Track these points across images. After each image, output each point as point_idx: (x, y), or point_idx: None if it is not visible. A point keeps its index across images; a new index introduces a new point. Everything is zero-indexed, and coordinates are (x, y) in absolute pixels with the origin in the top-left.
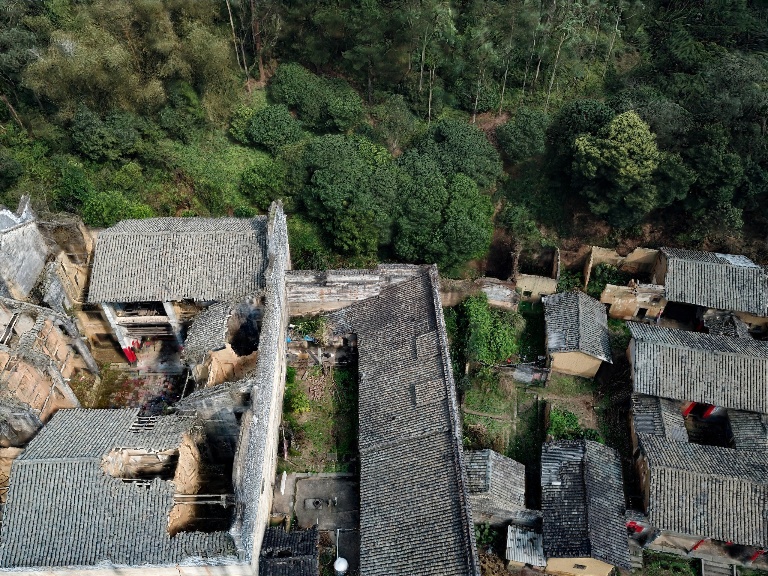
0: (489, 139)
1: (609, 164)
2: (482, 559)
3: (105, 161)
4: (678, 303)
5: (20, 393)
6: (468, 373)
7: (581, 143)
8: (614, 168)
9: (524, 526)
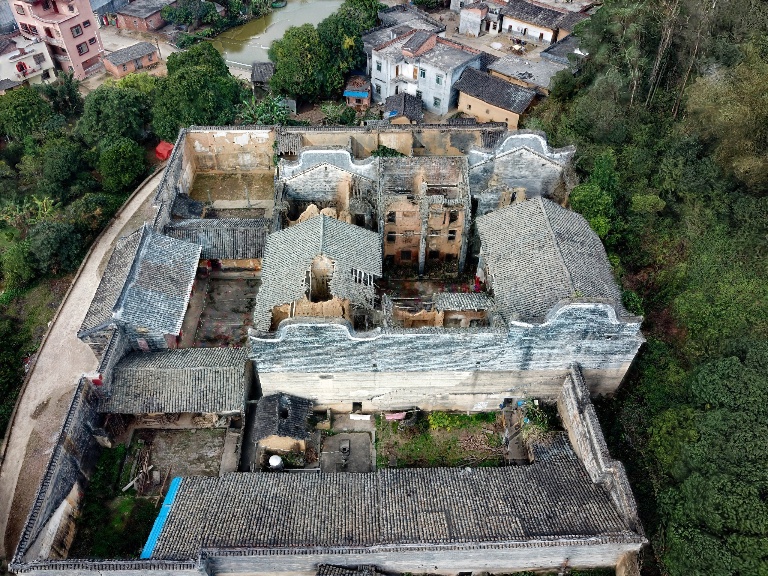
0: None
1: None
2: None
3: None
4: None
5: (401, 215)
6: None
7: None
8: None
9: None
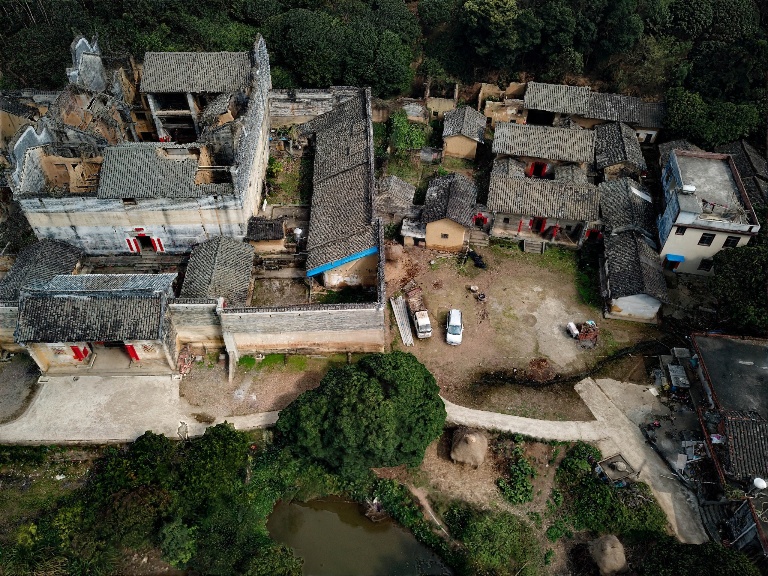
0: (416, 18)
1: (484, 15)
2: (388, 243)
3: (145, 26)
4: (537, 116)
5: None
6: (390, 155)
7: (467, 4)
8: (487, 18)
9: (413, 218)
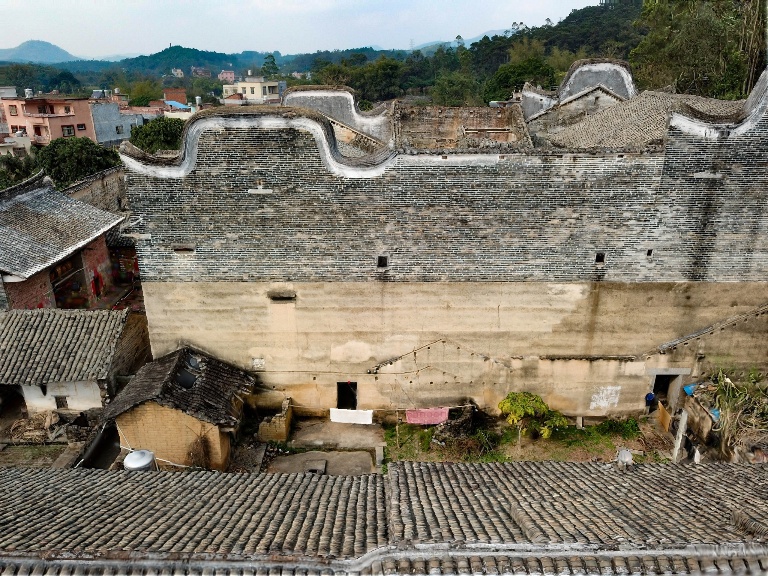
0: None
1: None
2: None
3: None
4: None
5: None
6: None
7: None
8: None
9: None
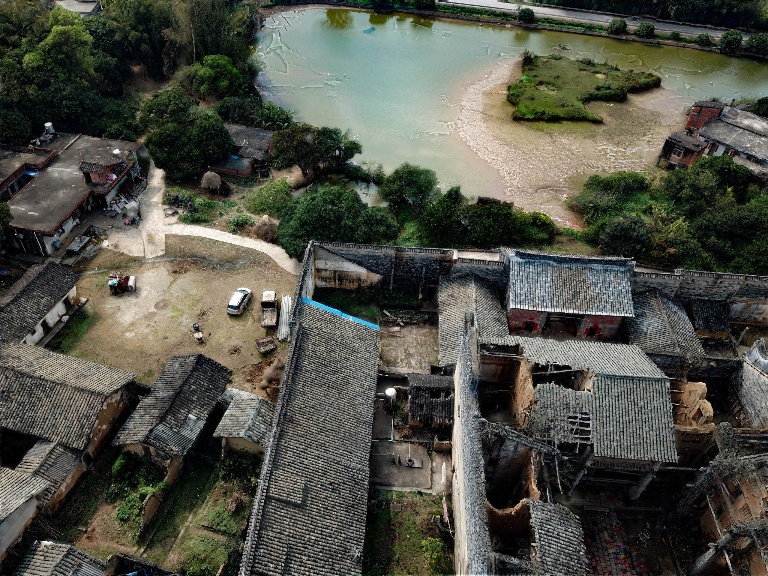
0: None
1: None
2: None
3: None
4: None
5: None
6: None
7: None
8: None
9: None
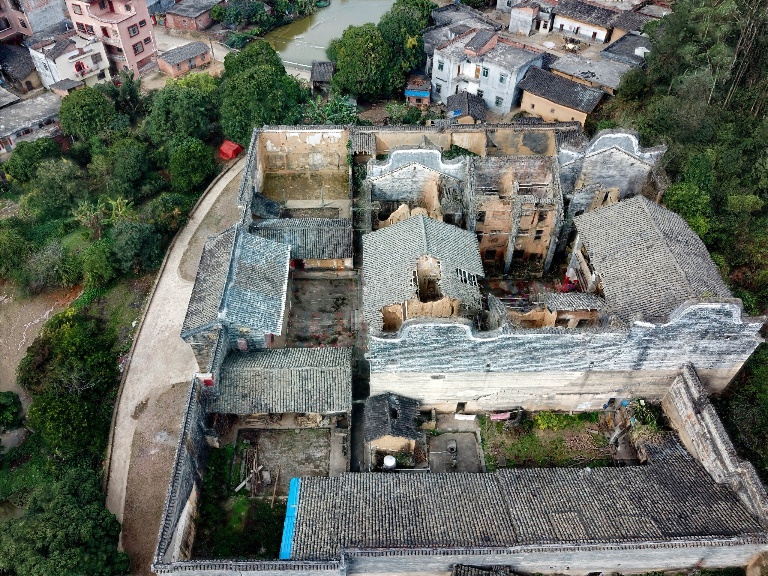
0: None
1: None
2: None
3: None
4: None
5: (491, 215)
6: None
7: None
8: None
9: None
